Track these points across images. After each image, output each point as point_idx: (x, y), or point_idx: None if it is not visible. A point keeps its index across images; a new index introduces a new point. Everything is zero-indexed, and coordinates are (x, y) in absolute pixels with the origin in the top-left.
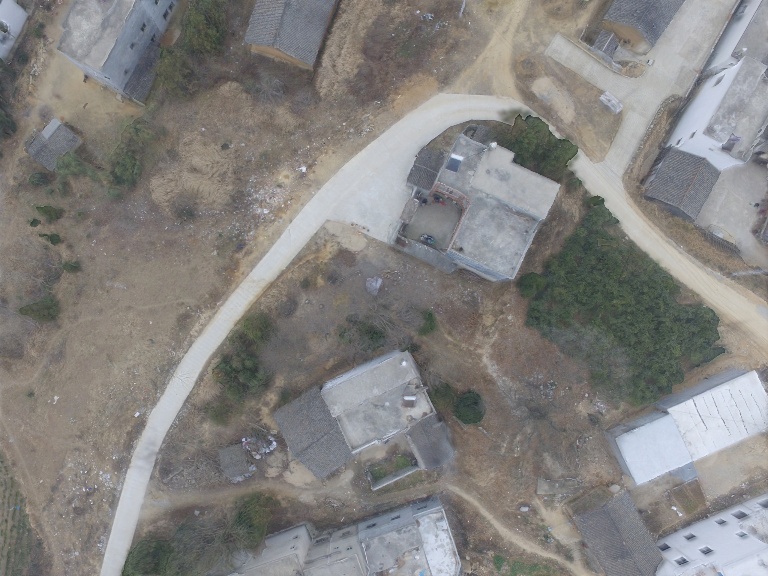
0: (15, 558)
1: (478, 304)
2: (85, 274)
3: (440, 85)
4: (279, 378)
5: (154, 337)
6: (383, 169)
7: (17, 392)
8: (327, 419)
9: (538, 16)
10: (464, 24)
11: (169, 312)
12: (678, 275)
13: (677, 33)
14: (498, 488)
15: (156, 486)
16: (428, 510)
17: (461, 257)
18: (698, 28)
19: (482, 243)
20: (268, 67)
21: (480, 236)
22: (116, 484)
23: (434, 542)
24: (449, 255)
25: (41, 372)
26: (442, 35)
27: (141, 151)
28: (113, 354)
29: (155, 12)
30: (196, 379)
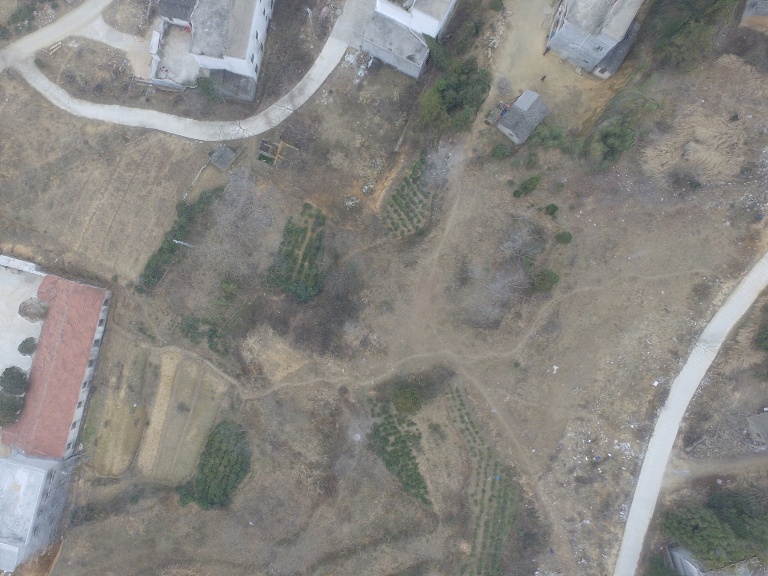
0: (495, 528)
1: None
2: (573, 245)
3: None
4: None
5: (669, 307)
6: None
7: (495, 362)
8: None
9: None
10: None
11: (682, 282)
12: None
13: None
14: None
15: (677, 455)
16: None
17: None
18: None
19: None
20: (757, 40)
21: None
22: (638, 452)
23: None
24: None
25: (526, 342)
26: None
27: (636, 122)
28: (621, 324)
29: None
30: (719, 348)
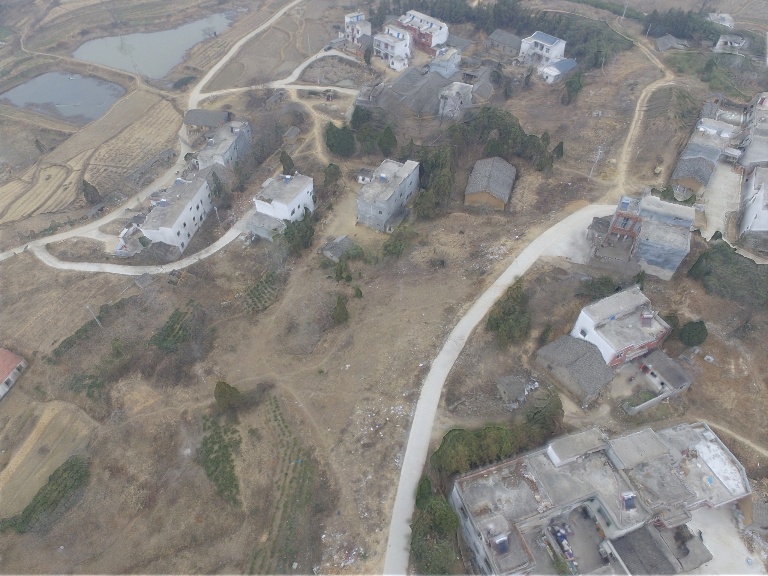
0: (292, 507)
1: (663, 293)
2: (366, 300)
3: (589, 202)
4: (534, 332)
5: (428, 320)
6: (569, 234)
7: (306, 374)
8: (584, 346)
9: (632, 180)
10: (591, 184)
11: (437, 308)
12: None
13: (714, 190)
14: (743, 408)
15: (443, 414)
16: (690, 425)
17: (647, 247)
18: (725, 189)
19: (658, 239)
20: None
21: (655, 236)
22: (409, 411)
23: (708, 452)
24: (636, 254)
25: (330, 357)
26: (581, 187)
27: (404, 241)
28: (395, 334)
29: (407, 190)
30: (466, 341)
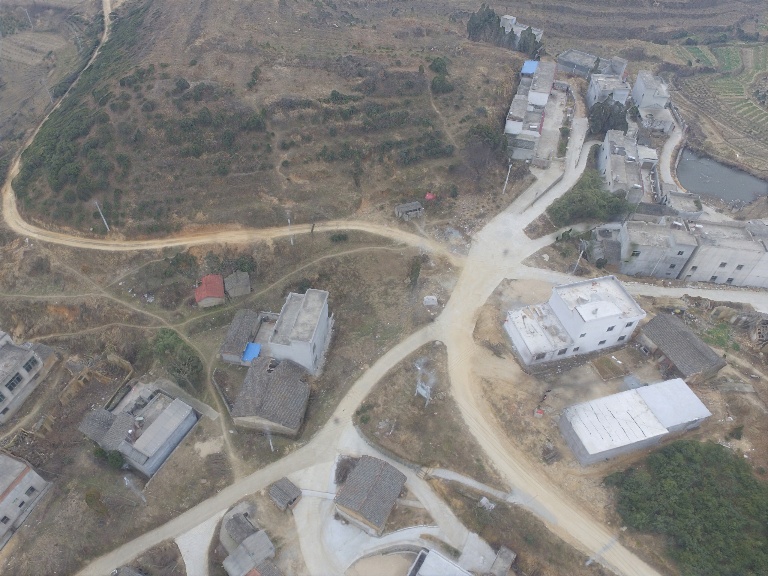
0: None
1: None
2: None
3: None
4: None
5: None
6: None
7: None
8: None
9: None
10: None
11: None
12: (651, 572)
13: None
14: None
15: None
16: None
17: None
18: None
19: None
20: None
21: None
22: None
23: None
24: None
25: None
26: None
27: None
28: None
29: None
30: None
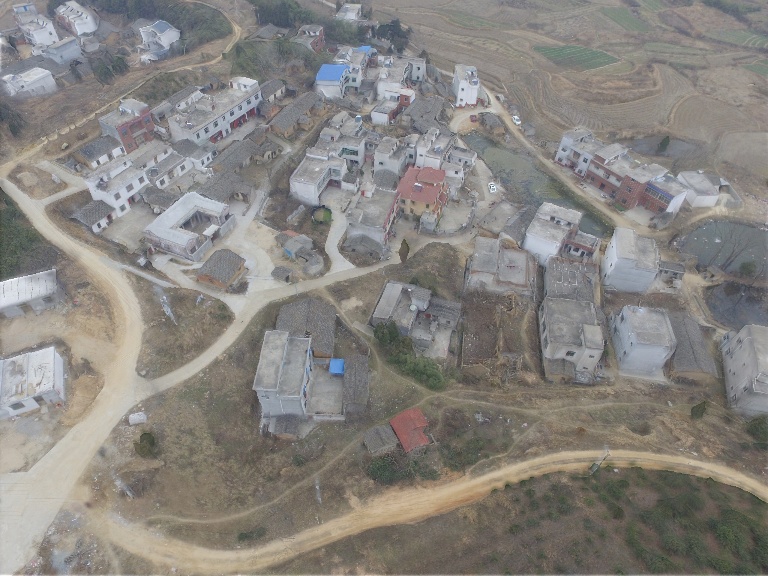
0: None
1: None
2: None
3: None
4: None
5: None
6: None
7: None
8: None
9: (40, 155)
10: None
11: None
12: (56, 243)
13: None
14: None
15: None
16: None
17: None
18: None
19: None
20: None
21: None
22: None
23: None
24: None
25: None
26: None
27: None
28: None
29: None
30: None
